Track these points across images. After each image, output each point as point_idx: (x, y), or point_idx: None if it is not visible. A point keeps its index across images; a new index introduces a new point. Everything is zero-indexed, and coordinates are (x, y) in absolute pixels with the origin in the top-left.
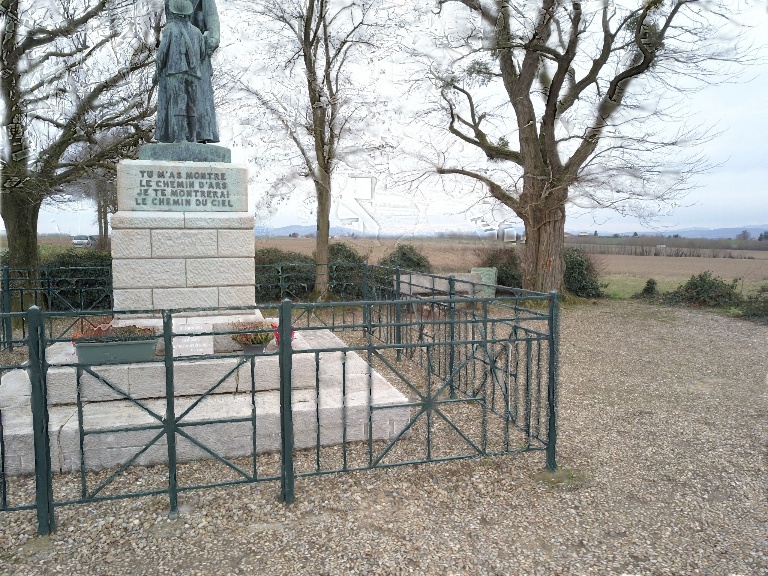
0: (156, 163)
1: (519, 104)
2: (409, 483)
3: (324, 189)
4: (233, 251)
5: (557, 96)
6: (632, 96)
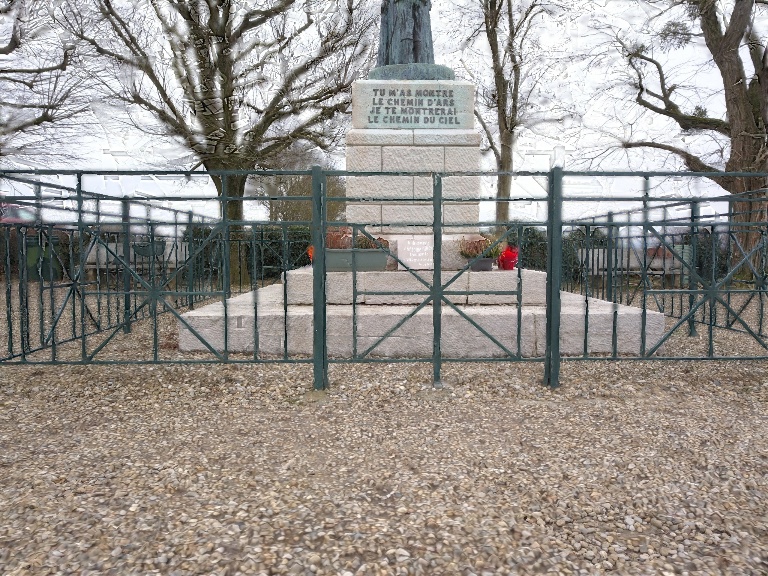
0: (388, 82)
1: (726, 62)
2: (686, 382)
3: (506, 161)
4: (459, 168)
5: None
6: None
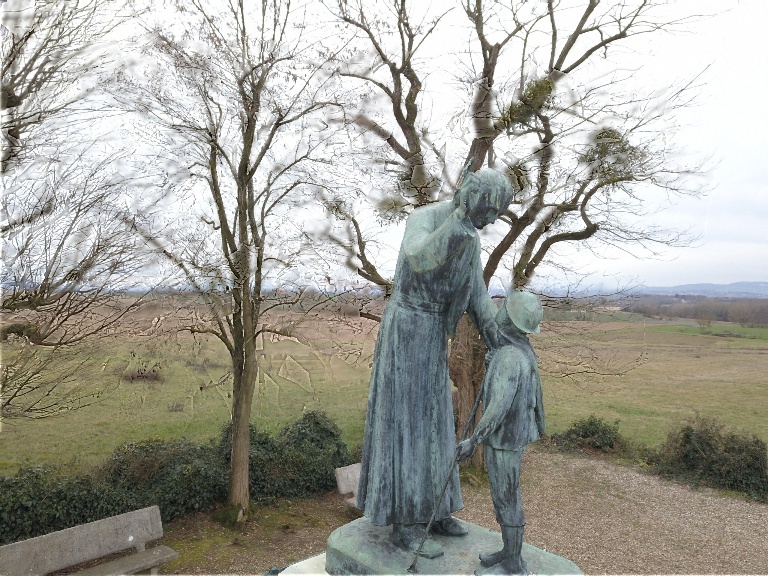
0: None
1: None
2: None
3: (251, 365)
4: None
5: (502, 255)
6: (558, 257)
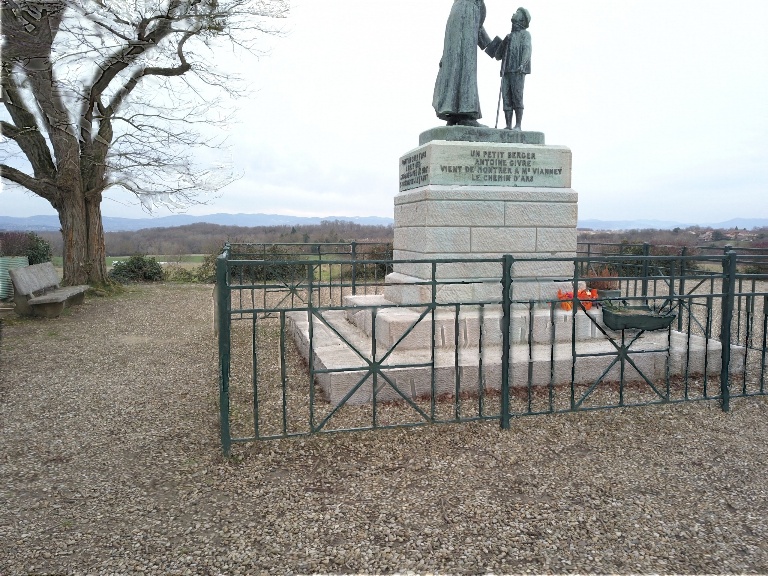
0: None
1: None
2: None
3: None
4: None
5: None
6: None
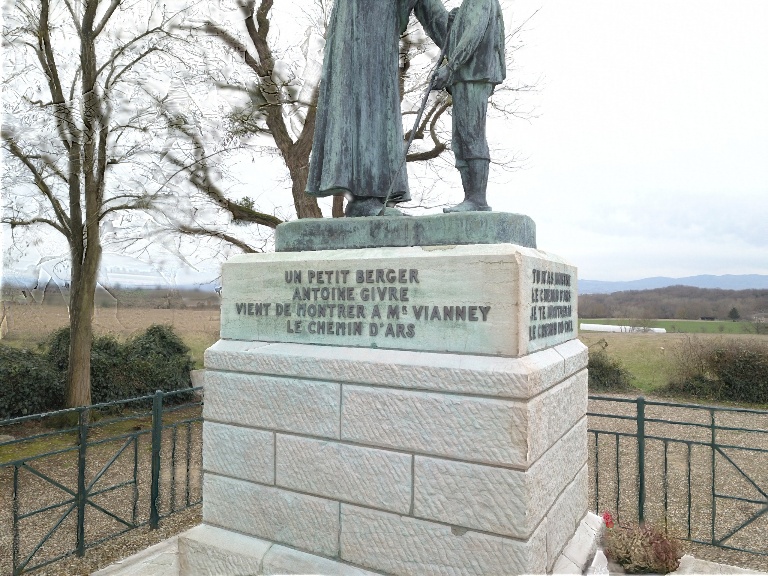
0: (536, 254)
1: None
2: None
3: (95, 250)
4: (581, 409)
5: None
6: None
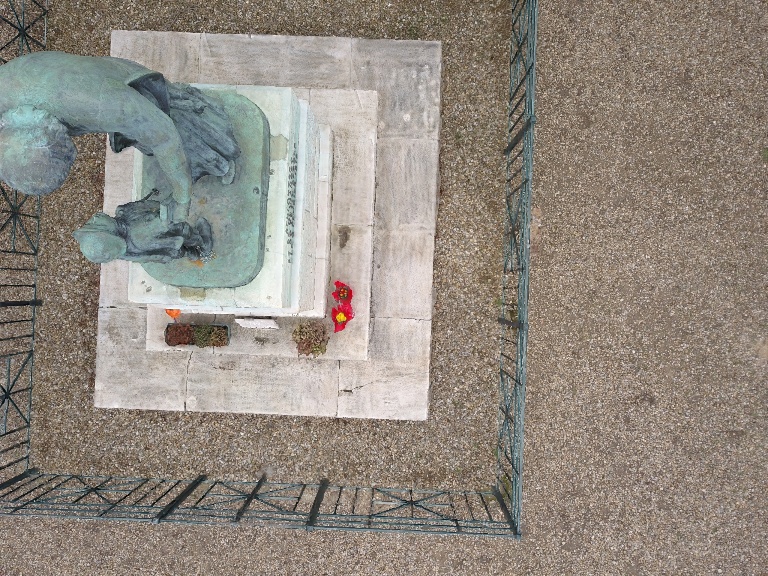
0: (171, 301)
1: None
2: (398, 484)
3: None
4: None
5: None
6: None
